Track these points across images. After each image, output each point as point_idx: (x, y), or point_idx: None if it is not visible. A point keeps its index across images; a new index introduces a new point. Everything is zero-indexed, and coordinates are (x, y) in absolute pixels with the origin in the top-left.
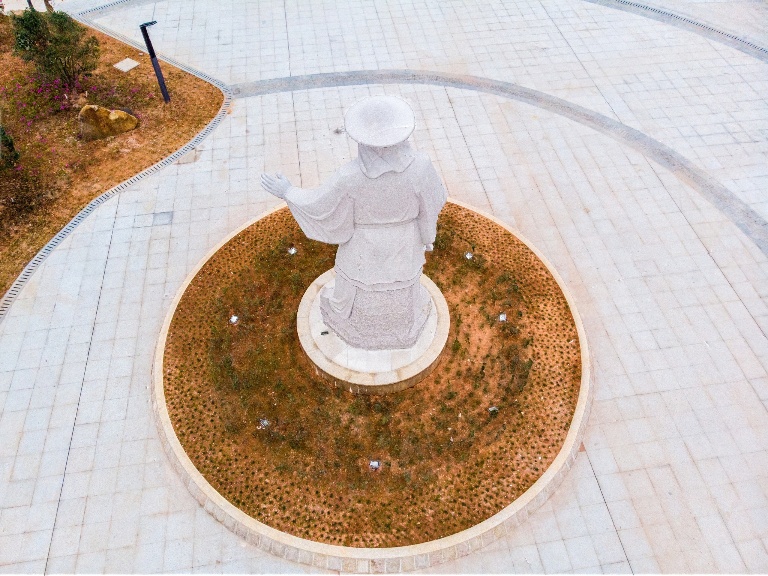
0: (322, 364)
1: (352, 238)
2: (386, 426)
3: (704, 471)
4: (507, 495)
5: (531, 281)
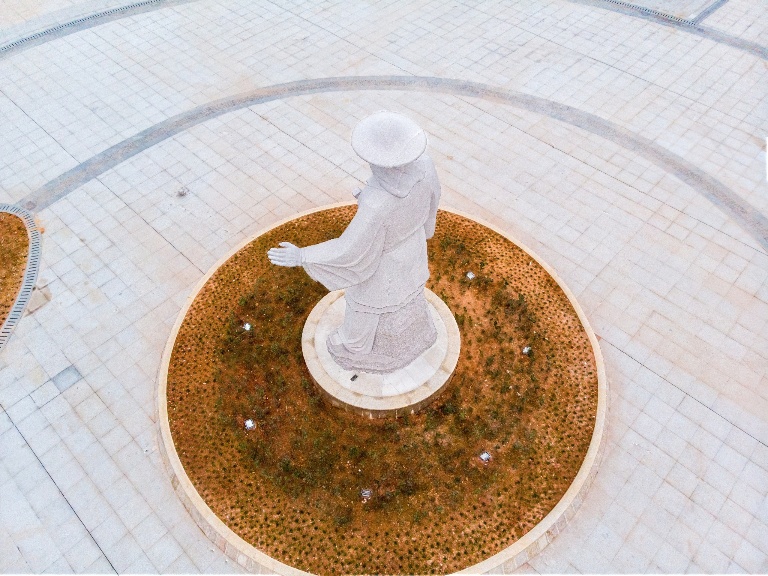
0: (377, 406)
1: (379, 267)
2: (464, 420)
3: (675, 301)
4: (589, 407)
5: (464, 235)
